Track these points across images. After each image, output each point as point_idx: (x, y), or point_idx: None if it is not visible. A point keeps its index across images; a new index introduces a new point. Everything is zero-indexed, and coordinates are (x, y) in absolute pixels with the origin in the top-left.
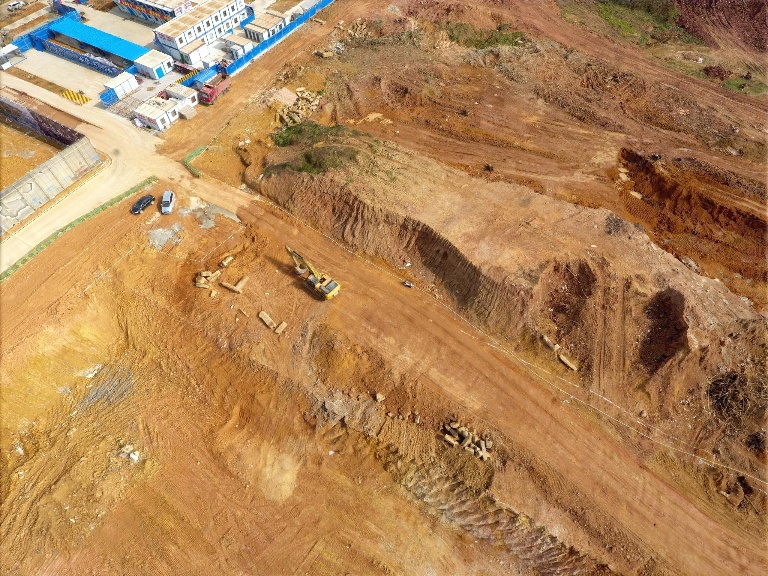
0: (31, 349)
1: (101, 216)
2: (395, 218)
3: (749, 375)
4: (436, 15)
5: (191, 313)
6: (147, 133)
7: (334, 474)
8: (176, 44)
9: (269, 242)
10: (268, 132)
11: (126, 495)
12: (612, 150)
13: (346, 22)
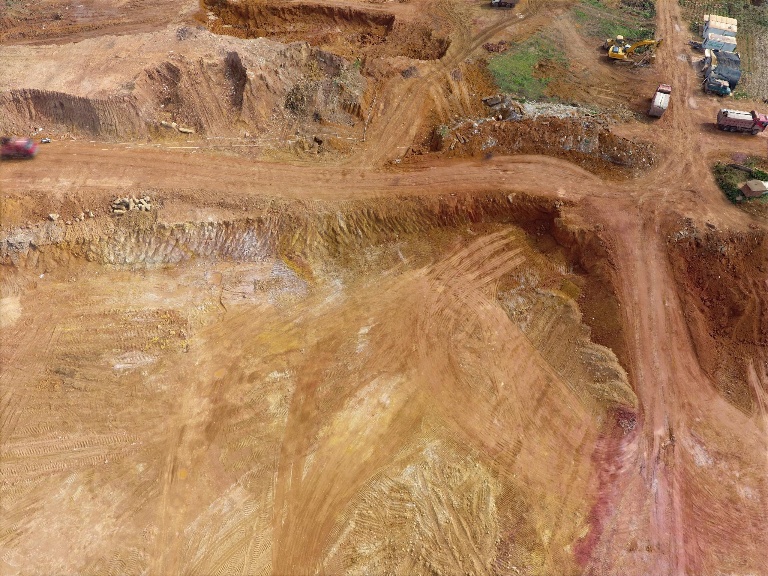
0: None
1: None
2: (2, 96)
3: None
4: None
5: None
6: None
7: (51, 286)
8: None
9: None
10: None
11: None
12: (194, 1)
13: None
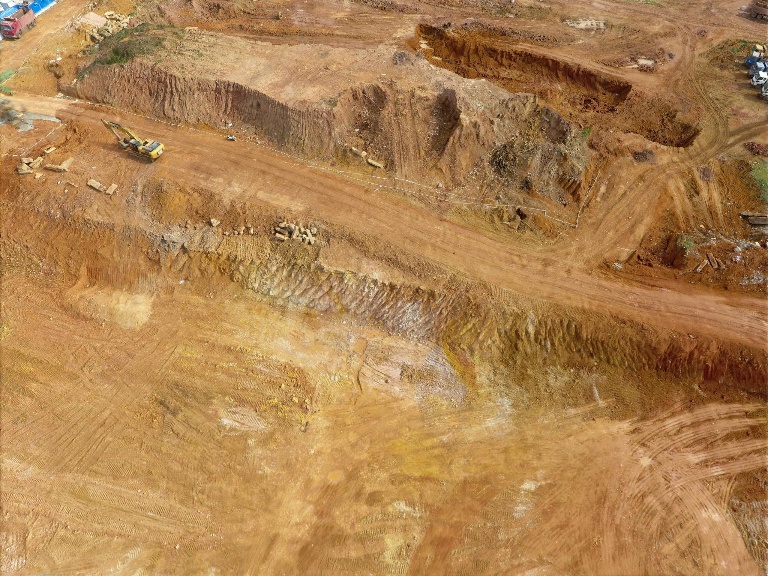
0: None
1: None
2: (206, 84)
3: (517, 143)
4: None
5: (18, 197)
6: None
7: (187, 297)
8: None
9: (91, 130)
10: (79, 49)
11: None
12: (410, 26)
13: None
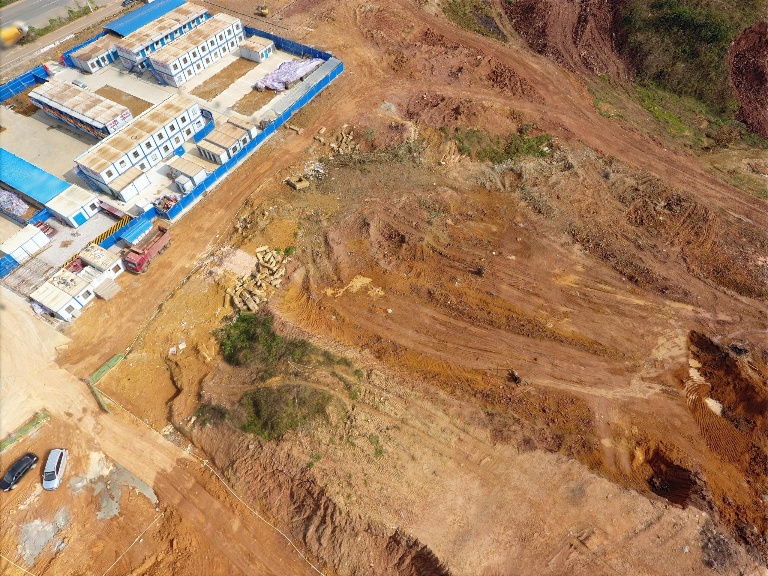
0: None
1: None
2: (381, 530)
3: None
4: (442, 119)
5: None
6: (48, 325)
7: None
8: (103, 179)
9: (195, 549)
10: (212, 328)
11: None
12: (678, 335)
13: (329, 129)
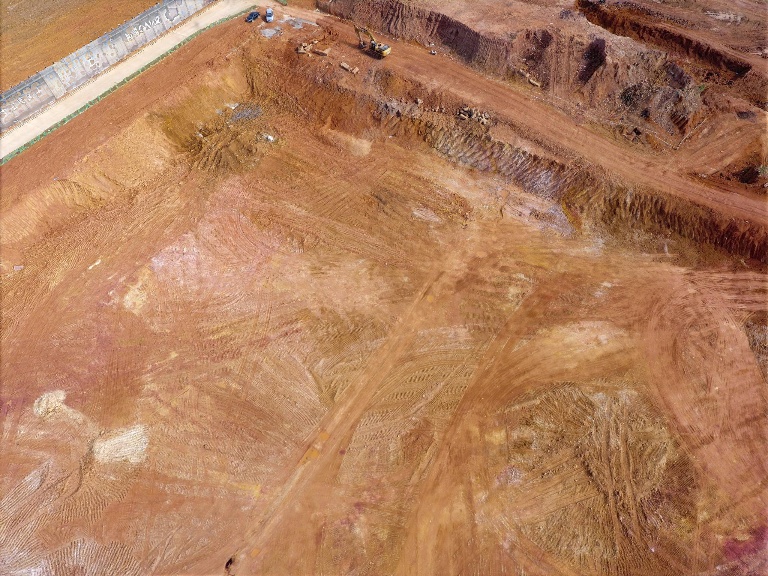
0: (201, 81)
1: (226, 23)
2: (424, 13)
3: None
4: None
5: (297, 66)
6: None
7: (393, 145)
8: None
9: (340, 34)
10: None
11: (270, 153)
12: None
13: None
